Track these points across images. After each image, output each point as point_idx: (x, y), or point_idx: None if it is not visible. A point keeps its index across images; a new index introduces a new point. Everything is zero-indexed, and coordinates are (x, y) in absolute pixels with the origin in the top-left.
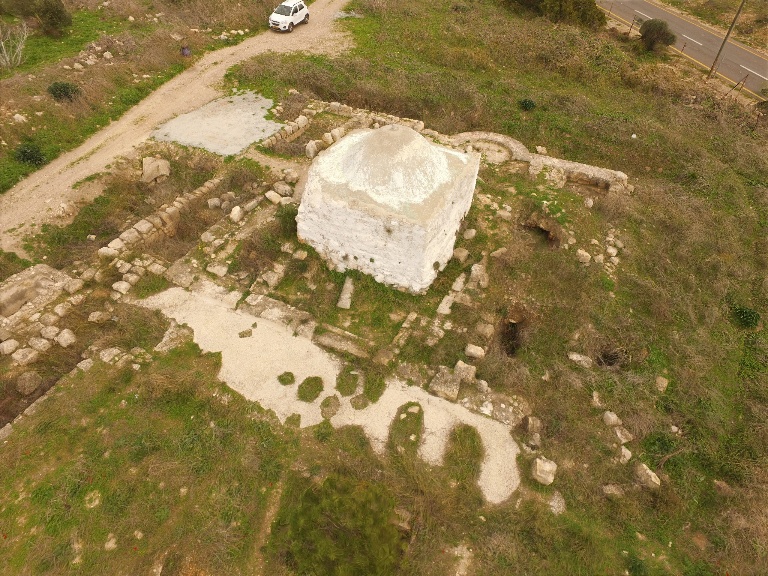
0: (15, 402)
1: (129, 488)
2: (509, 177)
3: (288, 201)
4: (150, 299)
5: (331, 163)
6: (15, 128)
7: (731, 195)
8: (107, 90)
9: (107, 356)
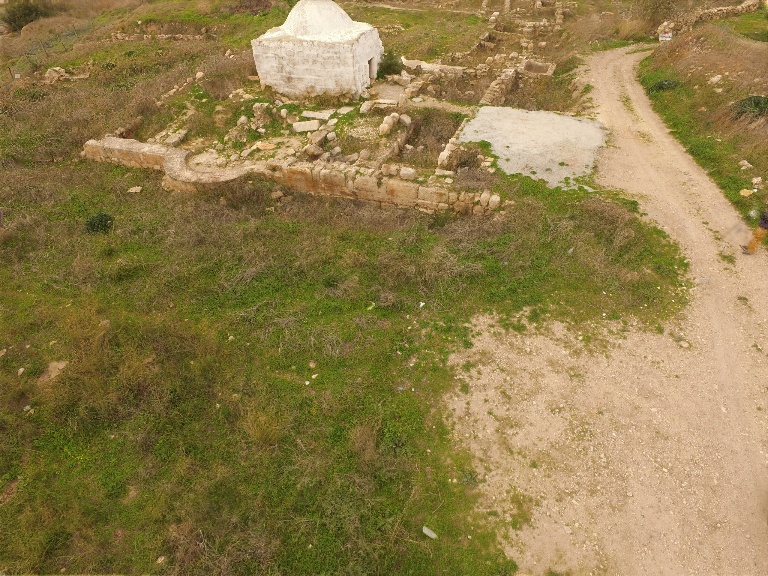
0: (489, 56)
1: (415, 39)
2: (211, 127)
3: (403, 77)
4: (462, 68)
5: (362, 26)
6: (698, 74)
7: (5, 139)
8: (739, 138)
9: (459, 53)
